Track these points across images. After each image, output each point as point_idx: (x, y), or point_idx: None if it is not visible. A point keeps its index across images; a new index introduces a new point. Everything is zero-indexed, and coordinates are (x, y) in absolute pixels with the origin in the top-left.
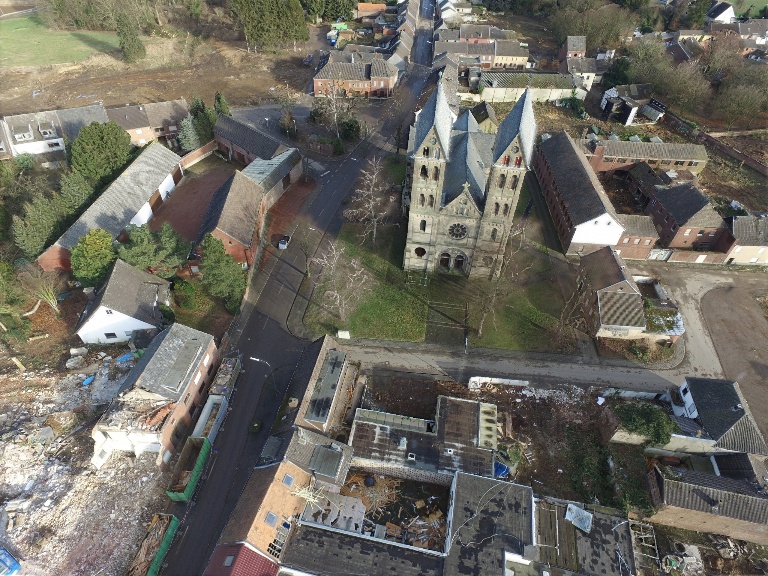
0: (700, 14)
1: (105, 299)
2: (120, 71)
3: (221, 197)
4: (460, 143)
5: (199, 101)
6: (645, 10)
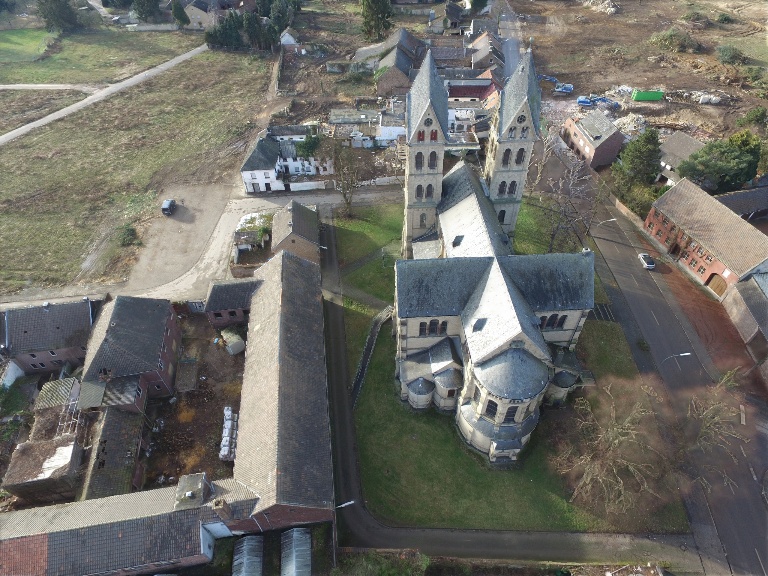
0: None
1: (681, 133)
2: None
3: None
4: None
5: None
6: None
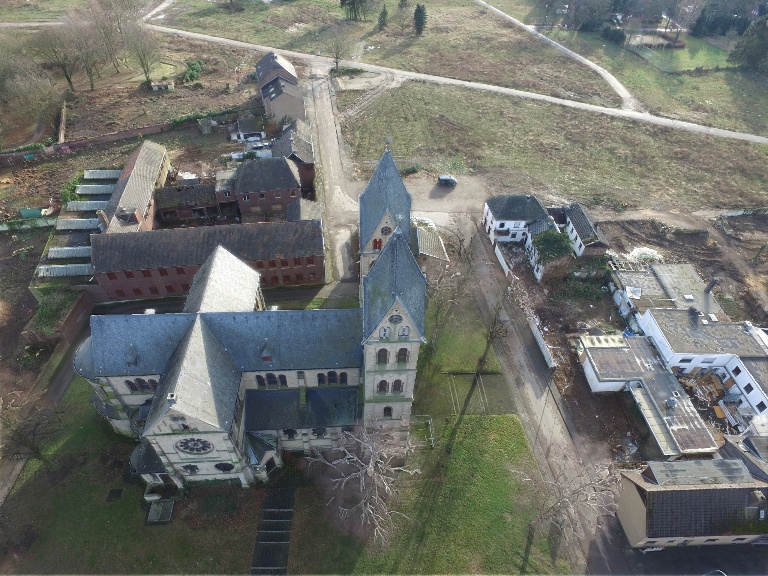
0: None
1: None
2: None
3: None
4: (223, 330)
5: None
6: None
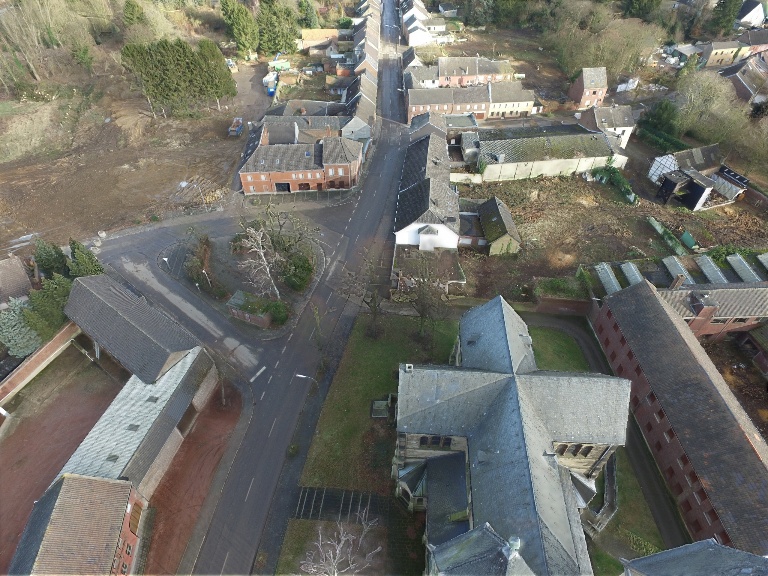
0: (729, 18)
1: None
2: None
3: (26, 559)
4: (501, 403)
5: (48, 248)
6: (658, 15)
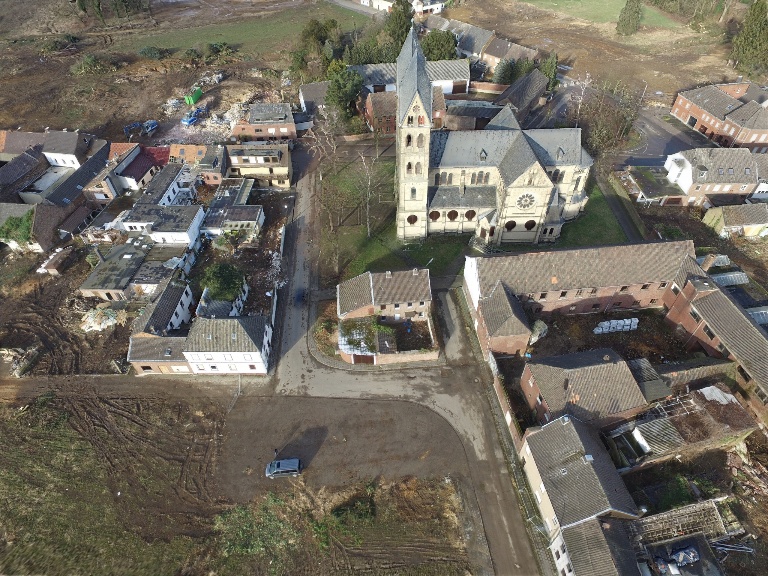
0: None
1: (304, 85)
2: (602, 37)
3: None
4: None
5: None
6: None
